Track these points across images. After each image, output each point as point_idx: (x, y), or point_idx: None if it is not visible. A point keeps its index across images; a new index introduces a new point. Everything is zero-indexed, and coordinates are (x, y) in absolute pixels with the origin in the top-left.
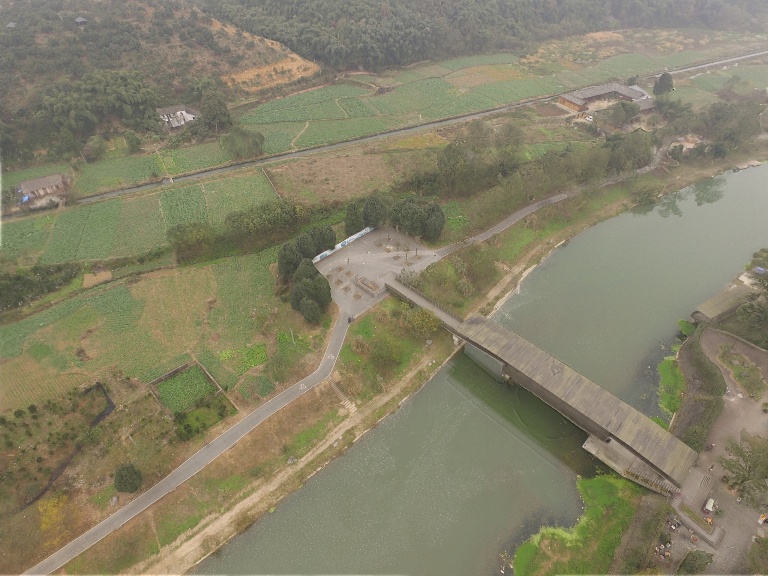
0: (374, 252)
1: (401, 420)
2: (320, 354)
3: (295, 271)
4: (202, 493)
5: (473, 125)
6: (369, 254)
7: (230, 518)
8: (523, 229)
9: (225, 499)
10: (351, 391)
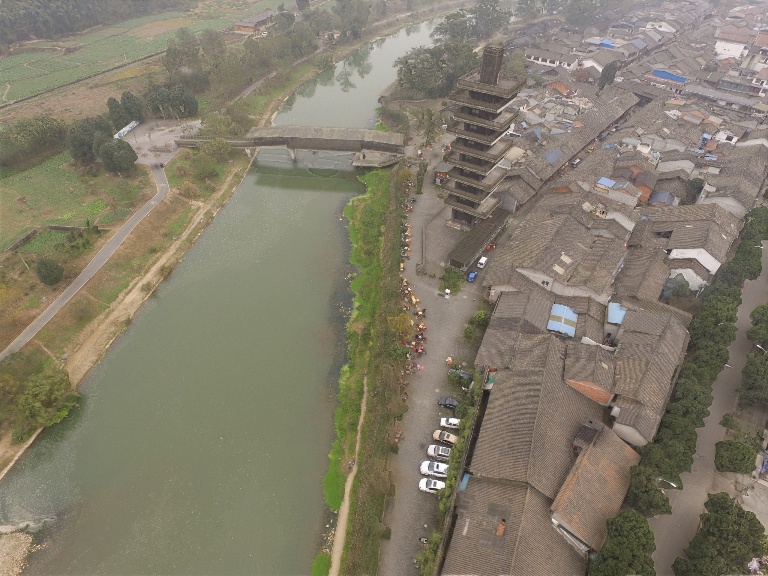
0: (151, 133)
1: (239, 197)
2: (153, 187)
3: (93, 144)
4: (118, 272)
5: (179, 32)
6: (147, 135)
7: (152, 274)
8: (256, 96)
9: (140, 266)
10: (193, 192)
